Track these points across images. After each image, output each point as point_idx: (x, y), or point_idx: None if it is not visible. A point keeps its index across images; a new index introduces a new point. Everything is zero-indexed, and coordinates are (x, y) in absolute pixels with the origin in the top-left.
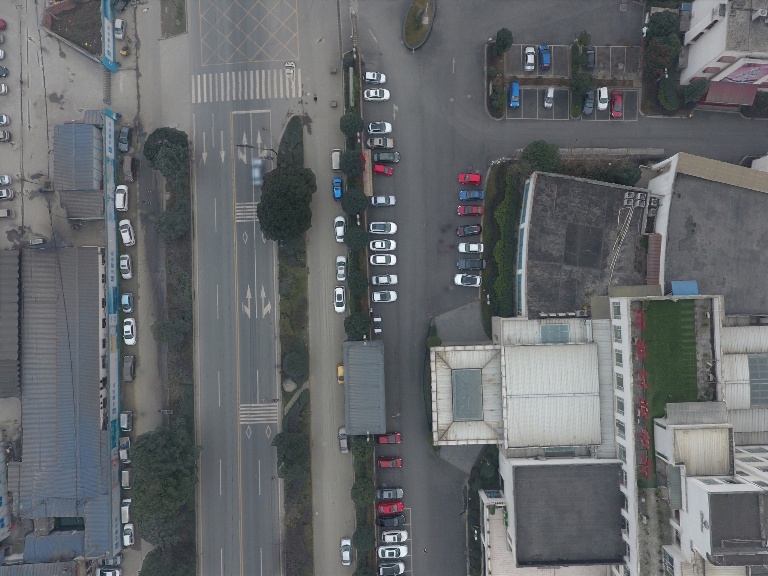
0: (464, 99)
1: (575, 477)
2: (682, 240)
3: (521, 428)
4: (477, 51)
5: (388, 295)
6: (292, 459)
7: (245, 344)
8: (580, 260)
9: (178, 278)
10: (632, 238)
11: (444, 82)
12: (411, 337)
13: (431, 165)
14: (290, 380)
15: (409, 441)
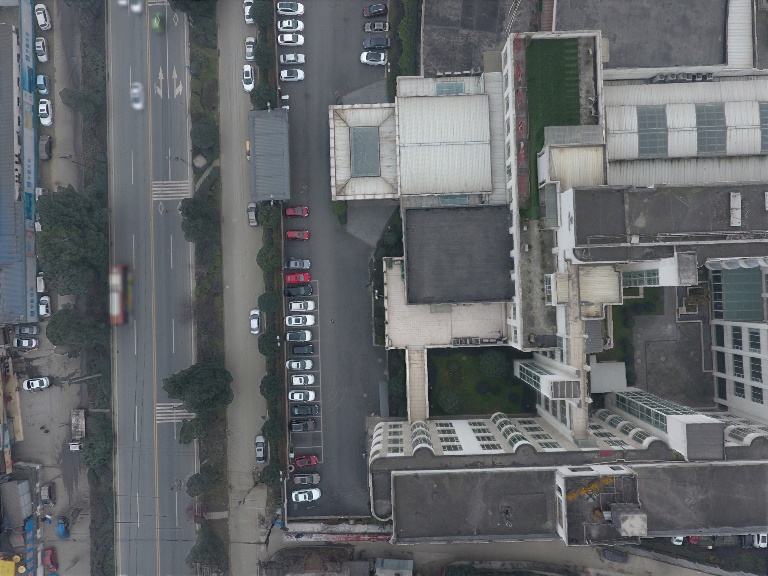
0: None
1: (466, 222)
2: None
3: (414, 176)
4: None
5: (295, 73)
6: (195, 216)
7: (157, 123)
8: (477, 24)
9: (92, 59)
10: (528, 3)
11: None
12: (319, 116)
13: None
14: (200, 155)
15: (317, 216)
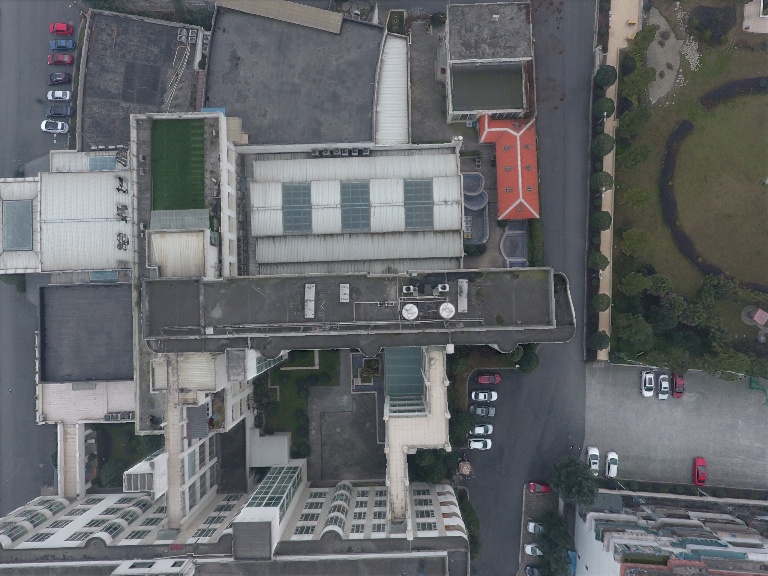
0: None
1: (105, 299)
2: (226, 73)
3: (56, 252)
4: None
5: None
6: None
7: None
8: (138, 97)
9: None
10: (189, 76)
11: None
12: None
13: (25, 17)
14: None
15: None
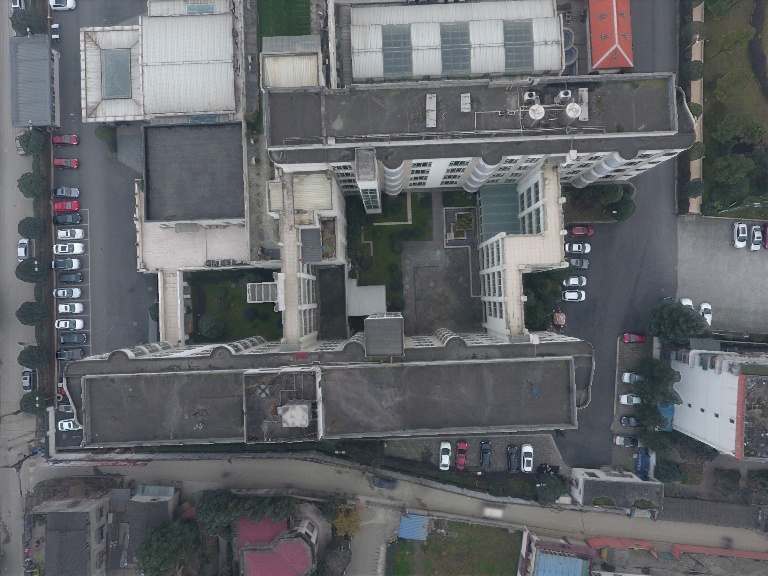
0: None
1: (208, 140)
2: None
3: (157, 95)
4: None
5: (65, 1)
6: None
7: None
8: None
9: None
10: None
11: None
12: None
13: None
14: None
15: (88, 145)
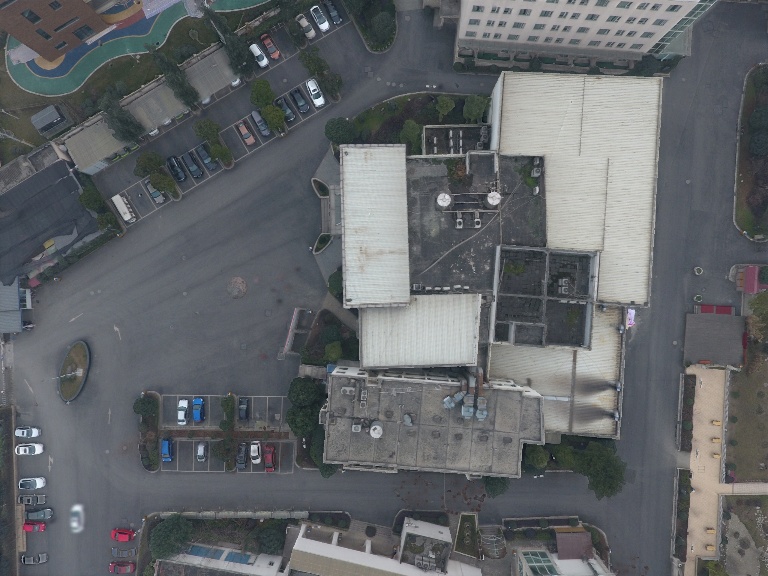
0: (120, 450)
1: None
2: None
3: None
4: (133, 401)
5: None
6: None
7: None
8: None
9: None
10: None
11: (100, 433)
12: None
13: (85, 519)
14: None
15: None
